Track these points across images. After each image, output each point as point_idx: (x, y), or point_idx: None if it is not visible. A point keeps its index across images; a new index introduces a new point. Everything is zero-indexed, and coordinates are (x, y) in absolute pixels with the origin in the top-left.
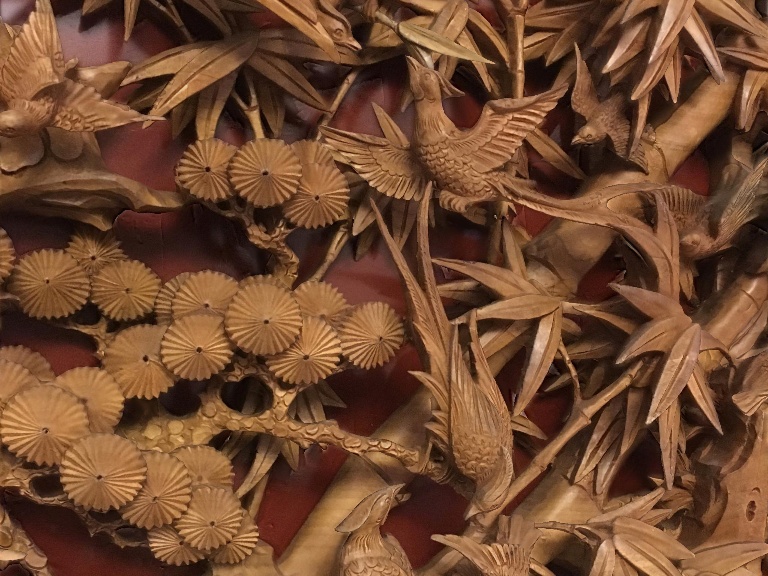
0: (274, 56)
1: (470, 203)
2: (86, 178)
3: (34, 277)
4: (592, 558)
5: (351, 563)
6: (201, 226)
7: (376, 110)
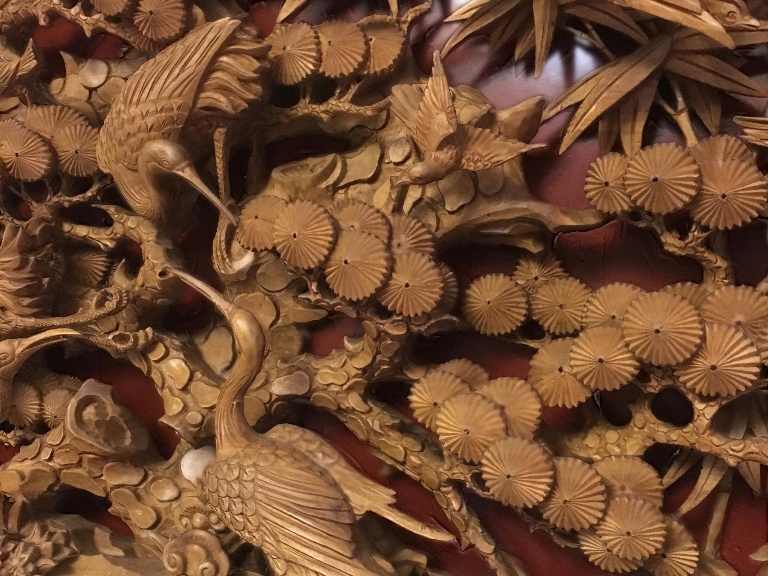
0: (694, 54)
1: None
2: (503, 208)
3: (479, 299)
4: None
5: None
6: (626, 239)
7: None
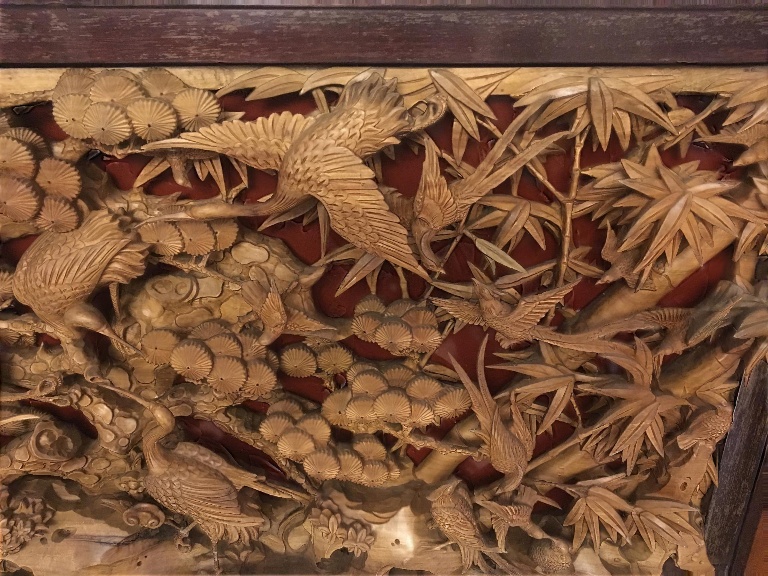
0: None
1: None
2: (307, 334)
3: (290, 363)
4: (573, 504)
5: (435, 508)
6: None
7: (470, 265)
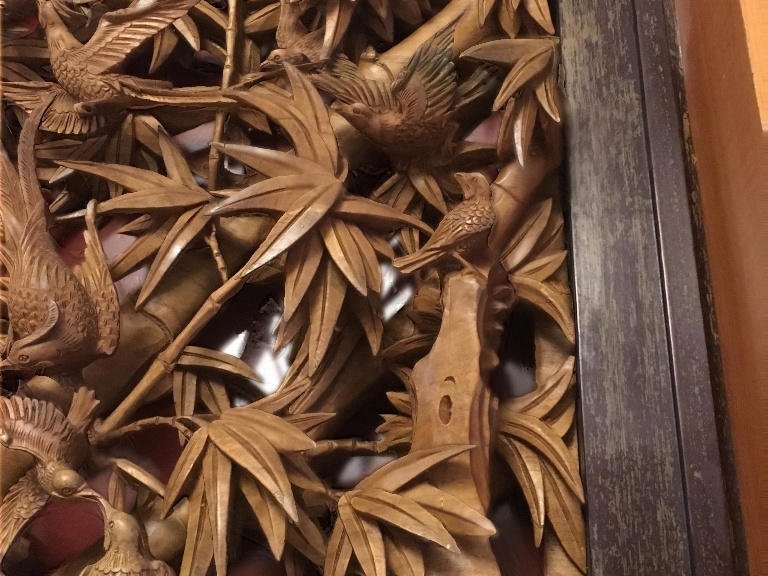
0: (9, 61)
1: (90, 104)
2: None
3: None
4: None
5: None
6: None
7: None
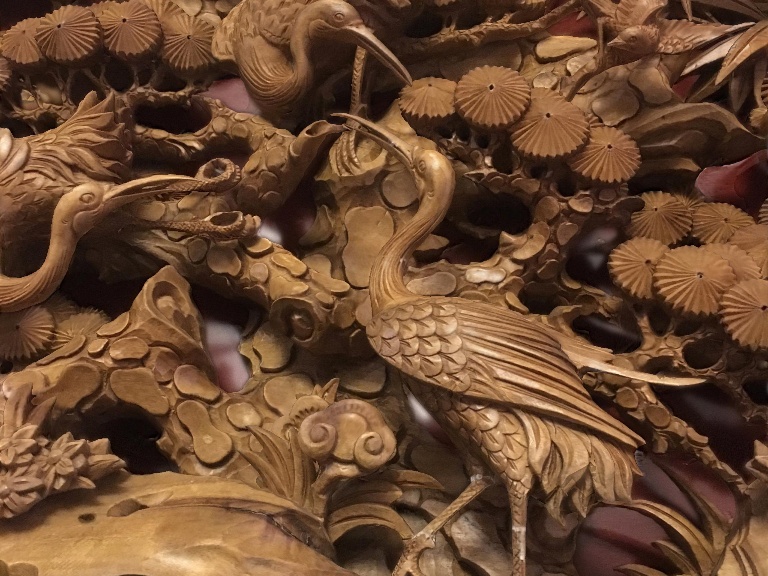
0: None
1: None
2: (682, 108)
3: (642, 210)
4: None
5: None
6: None
7: None
